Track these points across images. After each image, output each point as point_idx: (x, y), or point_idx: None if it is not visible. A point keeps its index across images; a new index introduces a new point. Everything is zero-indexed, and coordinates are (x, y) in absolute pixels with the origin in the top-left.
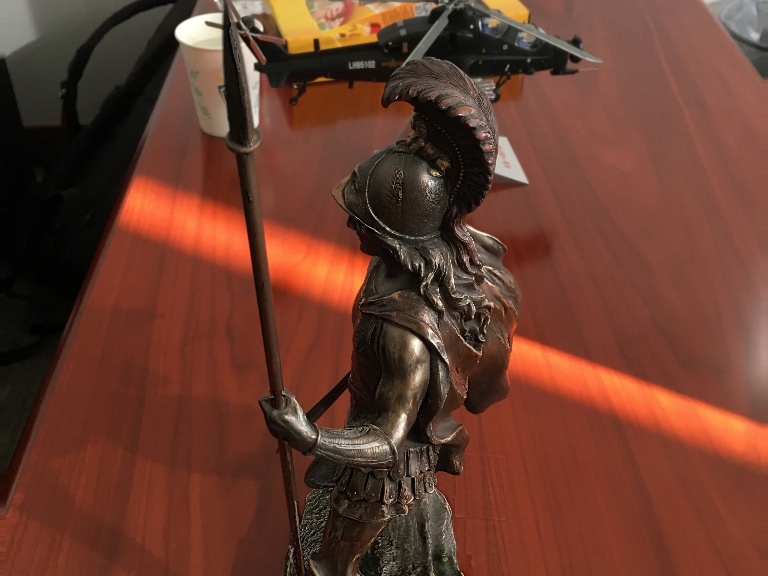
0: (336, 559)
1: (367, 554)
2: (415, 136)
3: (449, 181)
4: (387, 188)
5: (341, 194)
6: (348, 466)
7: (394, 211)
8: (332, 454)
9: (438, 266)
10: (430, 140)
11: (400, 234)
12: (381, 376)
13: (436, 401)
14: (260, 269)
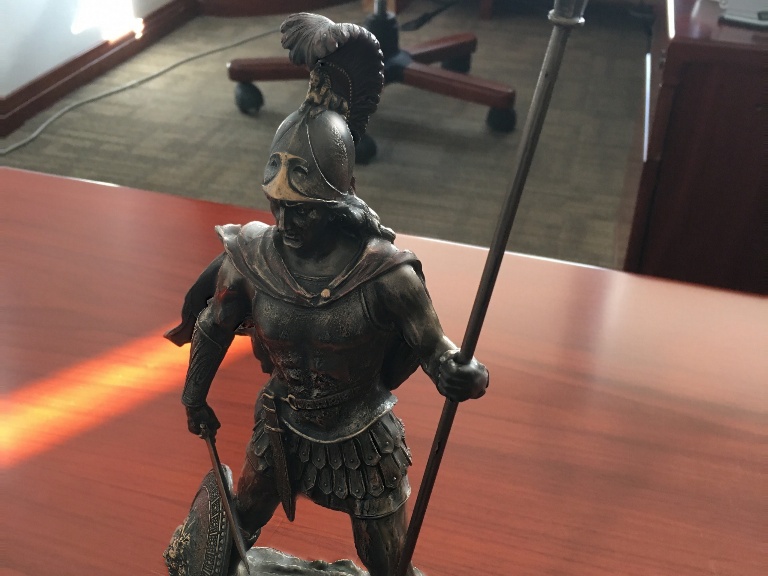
0: None
1: None
2: (326, 90)
3: None
4: (334, 150)
5: (291, 190)
6: (374, 465)
7: (344, 169)
8: None
9: None
10: (332, 89)
11: (344, 194)
12: (405, 325)
13: None
14: None
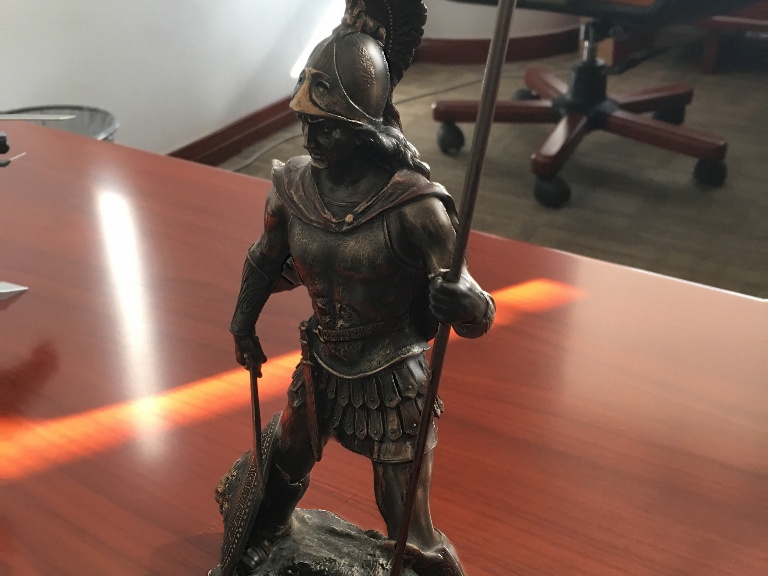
0: (418, 517)
1: None
2: (358, 11)
3: (384, 52)
4: (360, 69)
5: (310, 103)
6: (393, 406)
7: (371, 91)
8: (490, 313)
9: (402, 140)
10: (367, 12)
11: (373, 118)
12: (427, 258)
13: (466, 258)
14: (500, 68)
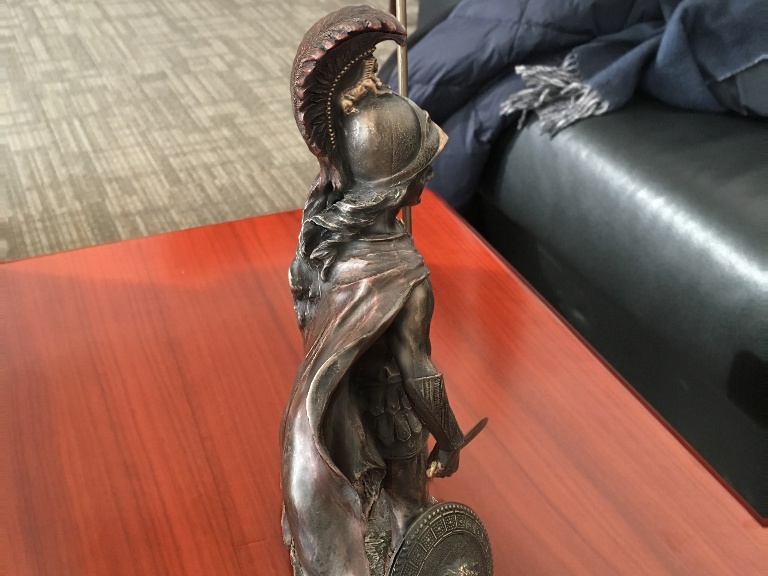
0: None
1: None
2: None
3: None
4: None
5: None
6: None
7: None
8: None
9: None
10: None
11: None
12: None
13: None
14: None
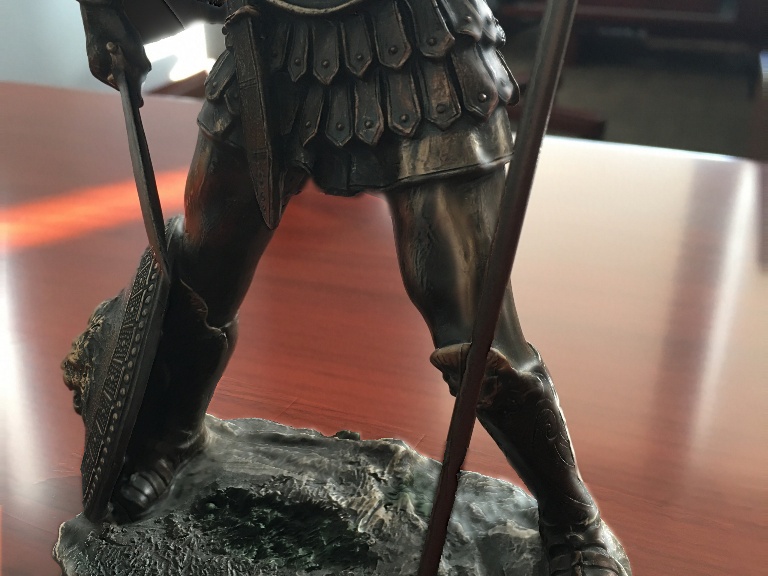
0: None
1: (280, 520)
2: None
3: None
4: None
5: None
6: (440, 53)
7: None
8: None
9: None
10: None
11: None
12: None
13: None
14: None
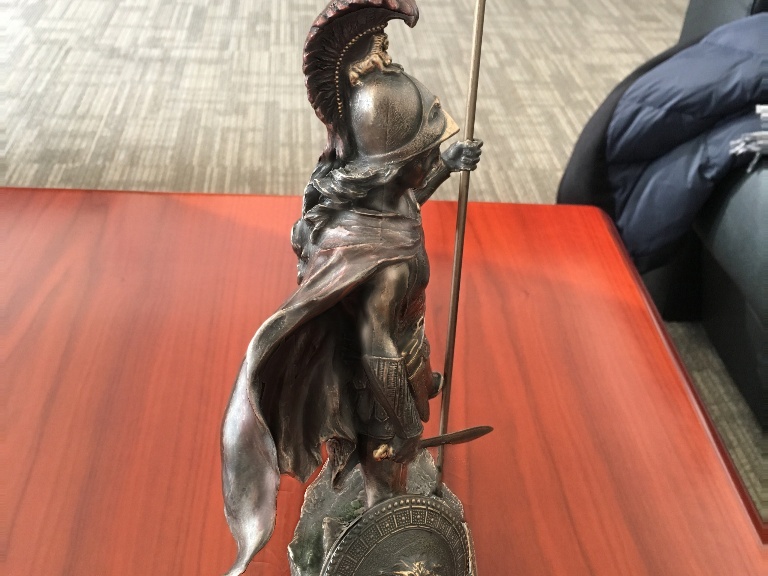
0: None
1: None
2: None
3: None
4: None
5: None
6: None
7: None
8: None
9: None
10: None
11: None
12: None
13: None
14: None
